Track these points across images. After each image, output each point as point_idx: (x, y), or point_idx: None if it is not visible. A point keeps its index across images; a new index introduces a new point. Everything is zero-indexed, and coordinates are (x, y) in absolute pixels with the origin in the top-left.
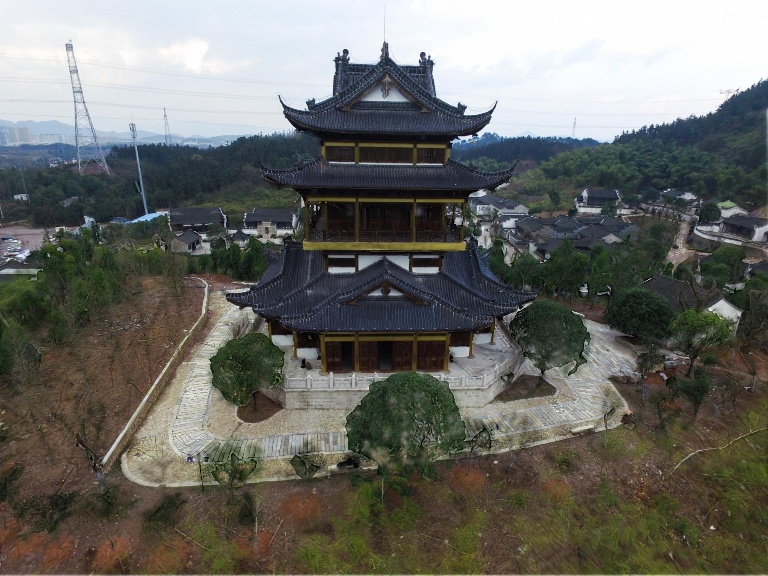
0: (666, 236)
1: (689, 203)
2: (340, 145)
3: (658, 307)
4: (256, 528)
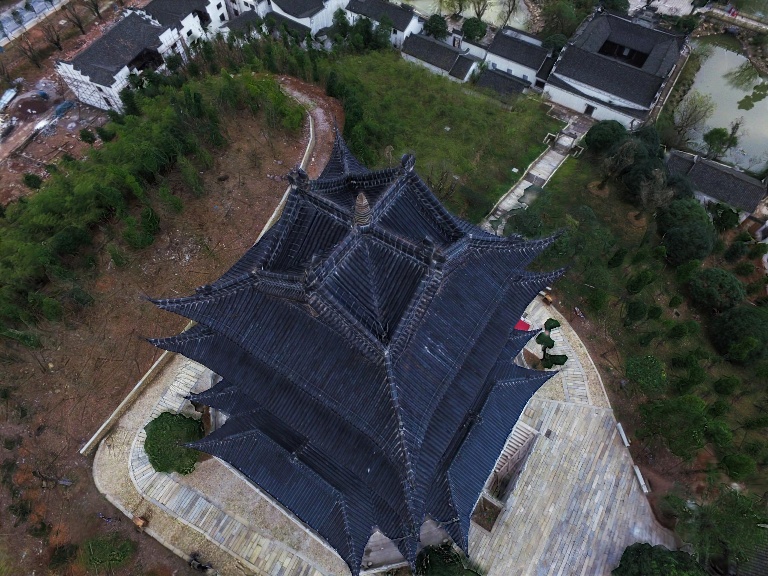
0: None
1: None
2: None
3: None
4: None
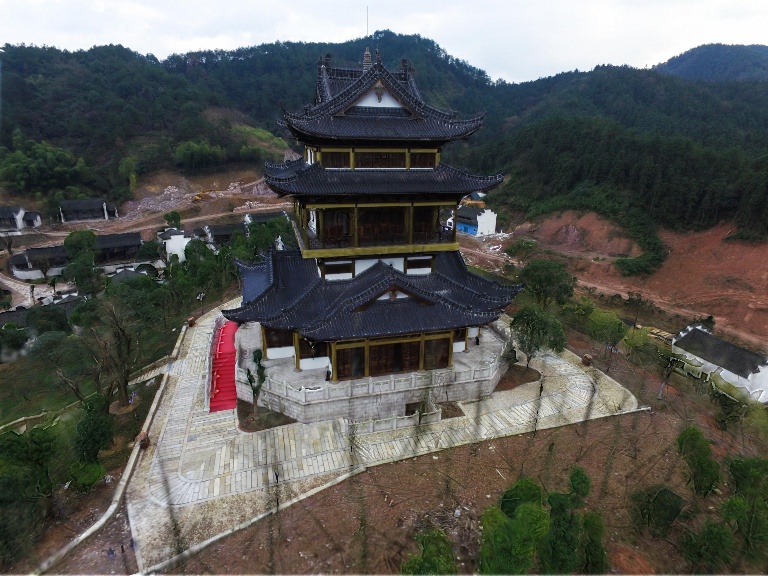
0: None
1: None
2: None
3: None
4: None
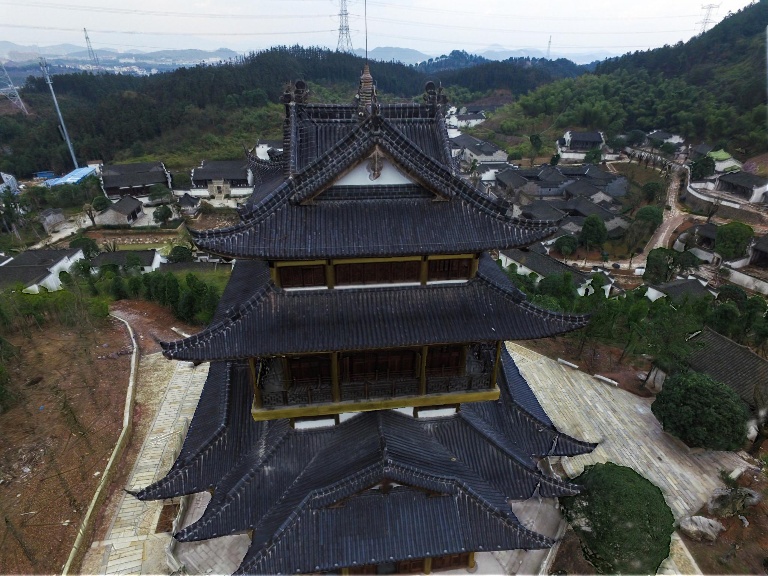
0: (659, 196)
1: (677, 148)
2: (301, 264)
3: (732, 414)
4: None
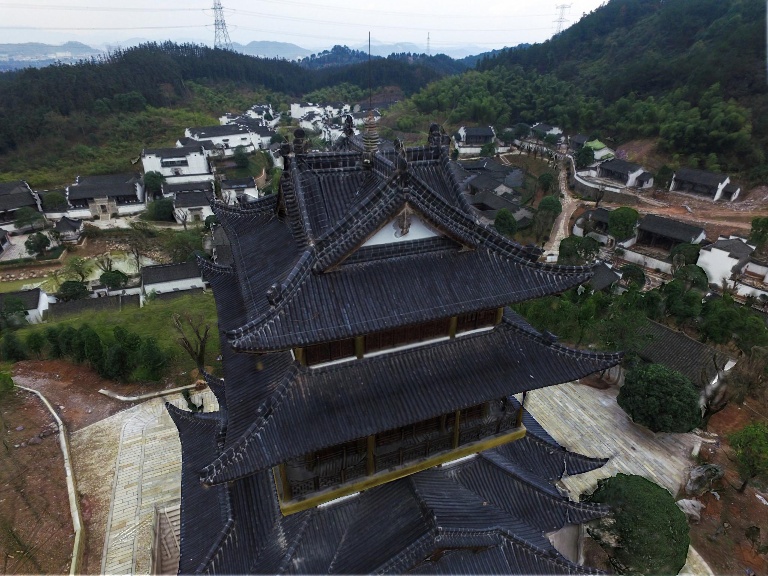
0: (554, 186)
1: (558, 139)
2: None
3: (690, 399)
4: None
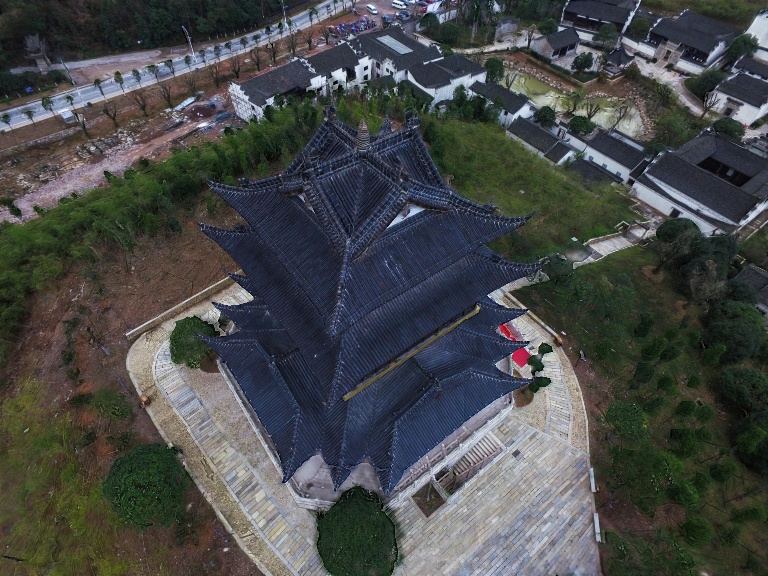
0: None
1: None
2: None
3: None
4: (78, 451)
